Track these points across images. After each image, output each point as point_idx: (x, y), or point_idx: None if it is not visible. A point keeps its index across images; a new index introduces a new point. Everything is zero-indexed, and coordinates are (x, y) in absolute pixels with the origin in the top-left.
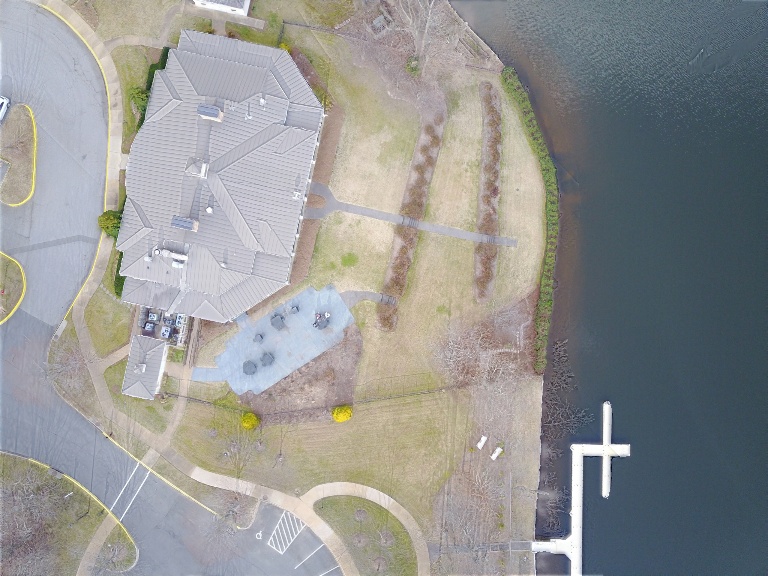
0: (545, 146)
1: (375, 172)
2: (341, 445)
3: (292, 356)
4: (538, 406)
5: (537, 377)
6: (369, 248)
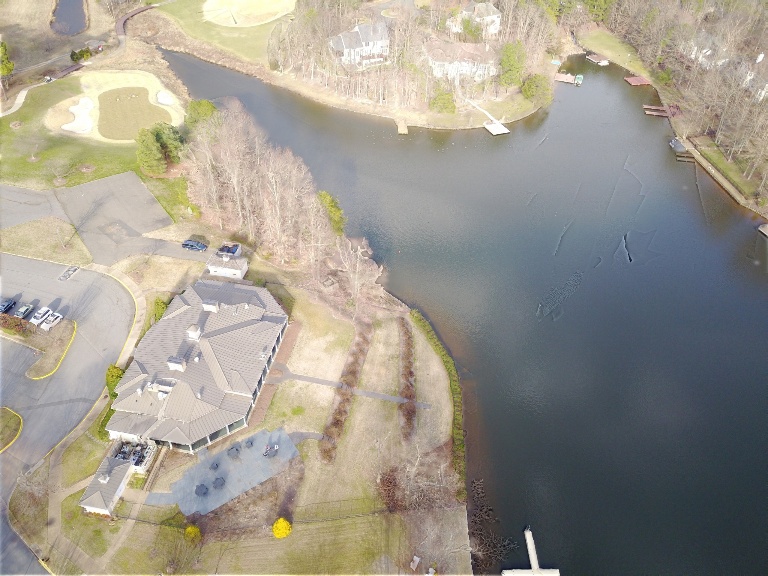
0: (444, 349)
1: (322, 357)
2: (277, 563)
3: (241, 482)
4: (465, 533)
5: (460, 508)
6: (315, 403)
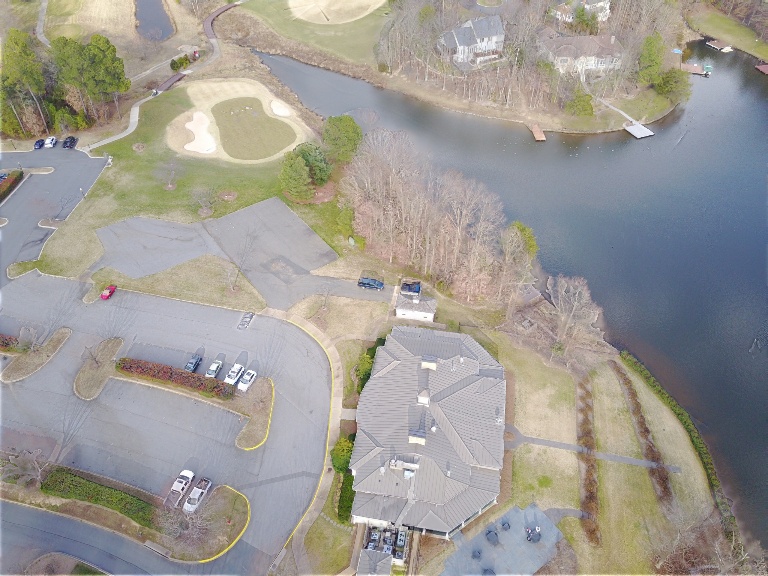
0: None
1: (549, 415)
2: None
3: (511, 573)
4: None
5: None
6: (559, 472)
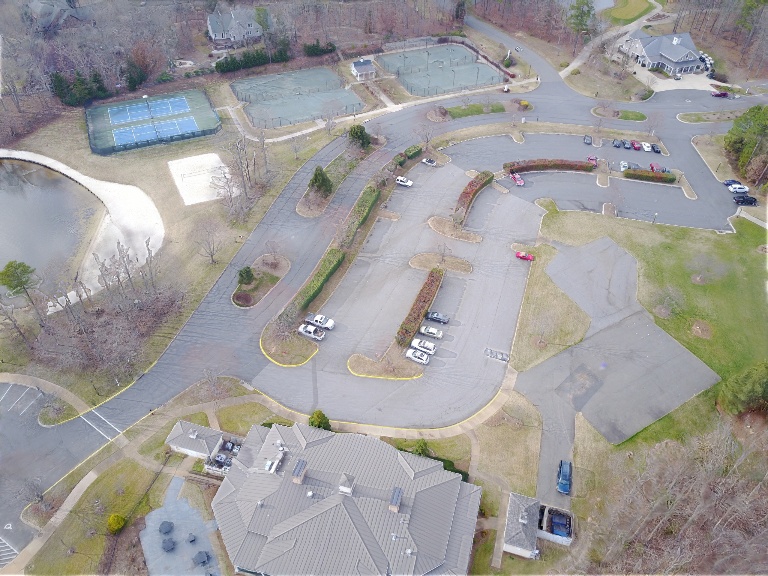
0: None
1: None
2: None
3: (164, 571)
4: None
5: None
6: None
